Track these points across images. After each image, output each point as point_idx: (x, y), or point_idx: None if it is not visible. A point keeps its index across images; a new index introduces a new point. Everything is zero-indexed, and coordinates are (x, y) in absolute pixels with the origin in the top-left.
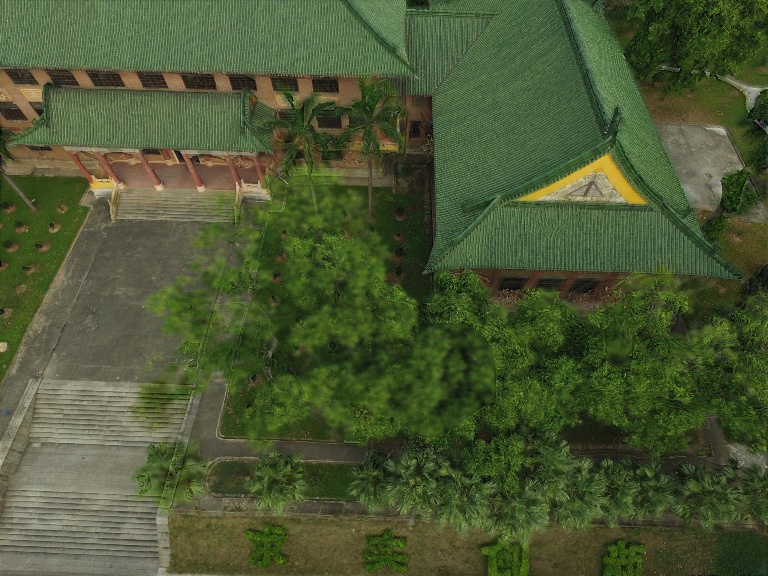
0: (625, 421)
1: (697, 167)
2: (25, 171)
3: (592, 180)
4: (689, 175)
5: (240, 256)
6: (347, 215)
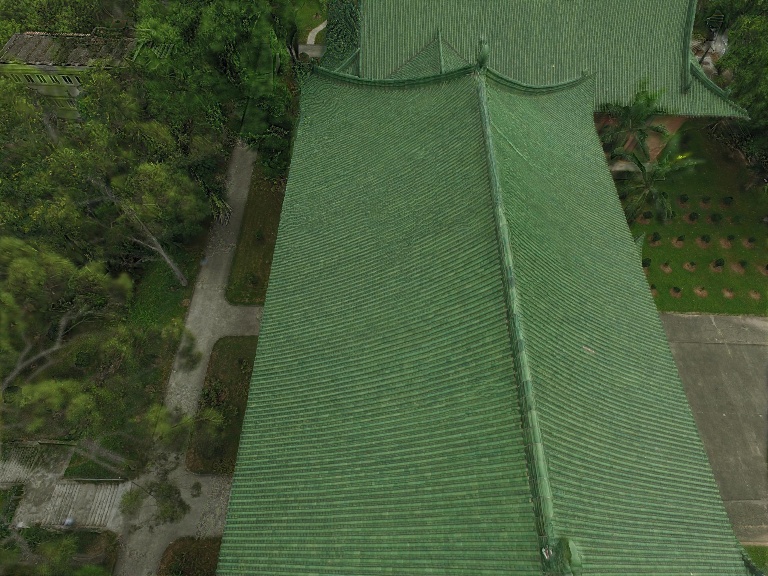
0: None
1: None
2: None
3: None
4: None
5: None
6: None
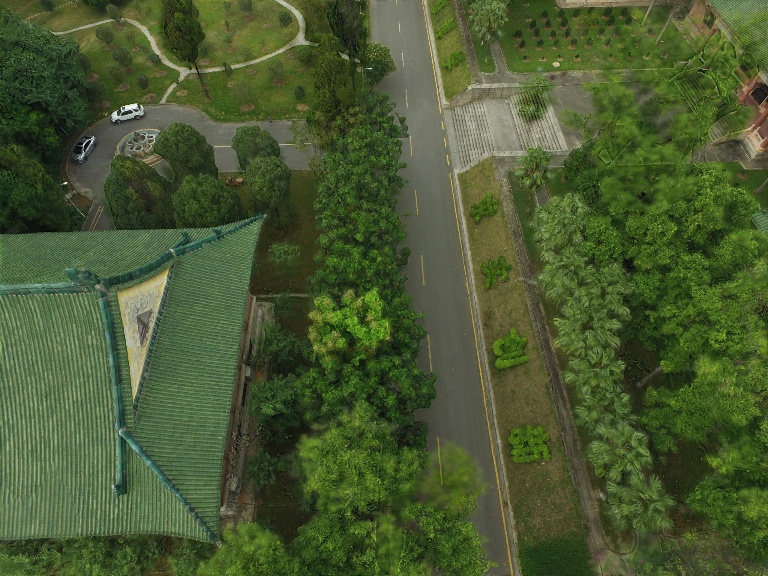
0: (669, 368)
1: None
2: (683, 31)
3: None
4: None
5: None
6: None
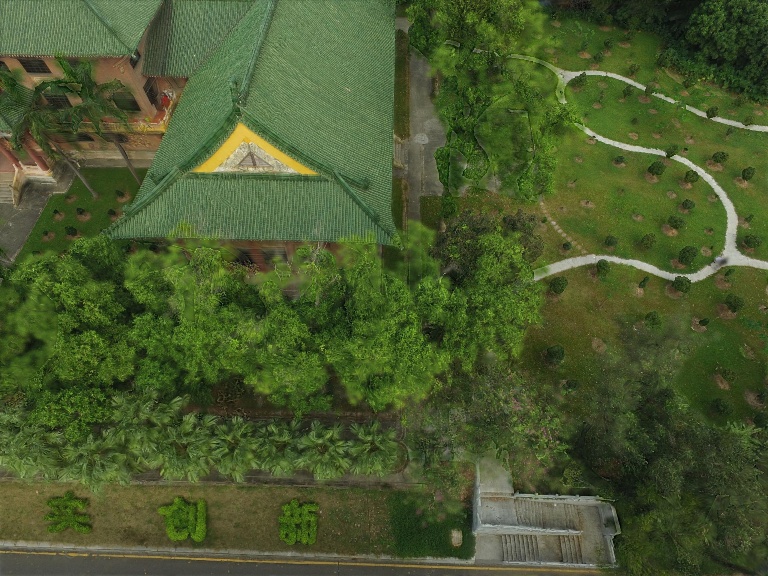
0: (252, 379)
1: (488, 147)
2: None
3: (249, 150)
4: None
5: (9, 235)
6: (124, 195)
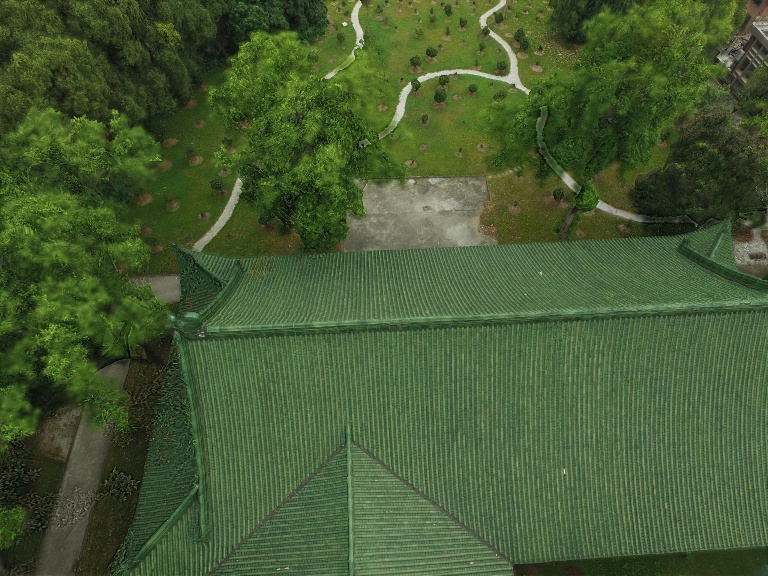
0: None
1: (415, 215)
2: None
3: None
4: (429, 224)
5: None
6: None
